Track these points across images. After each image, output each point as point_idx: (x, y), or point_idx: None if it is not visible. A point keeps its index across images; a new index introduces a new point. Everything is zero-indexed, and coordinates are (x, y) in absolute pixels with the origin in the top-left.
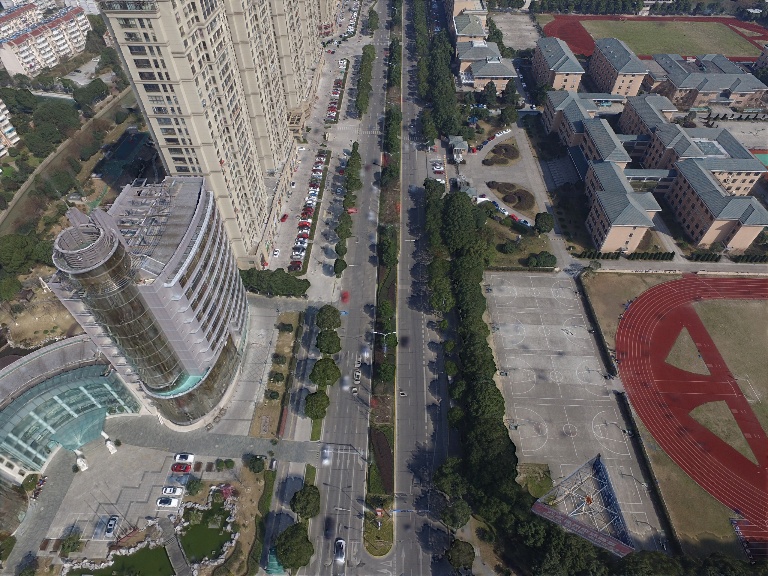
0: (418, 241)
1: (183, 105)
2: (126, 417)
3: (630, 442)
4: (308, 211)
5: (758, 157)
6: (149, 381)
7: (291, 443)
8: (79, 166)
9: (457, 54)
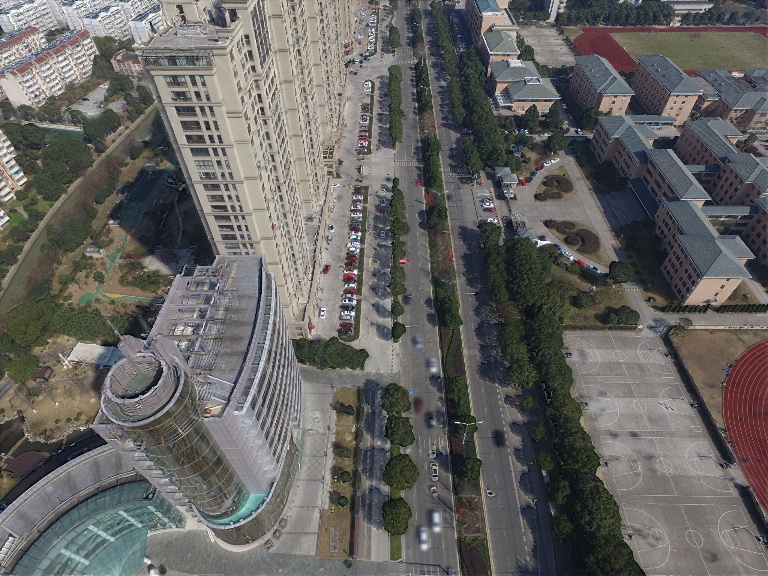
0: (478, 294)
1: (236, 170)
2: (170, 533)
3: (767, 553)
4: (352, 260)
5: None
6: (205, 509)
7: (368, 564)
8: (94, 211)
9: (490, 74)
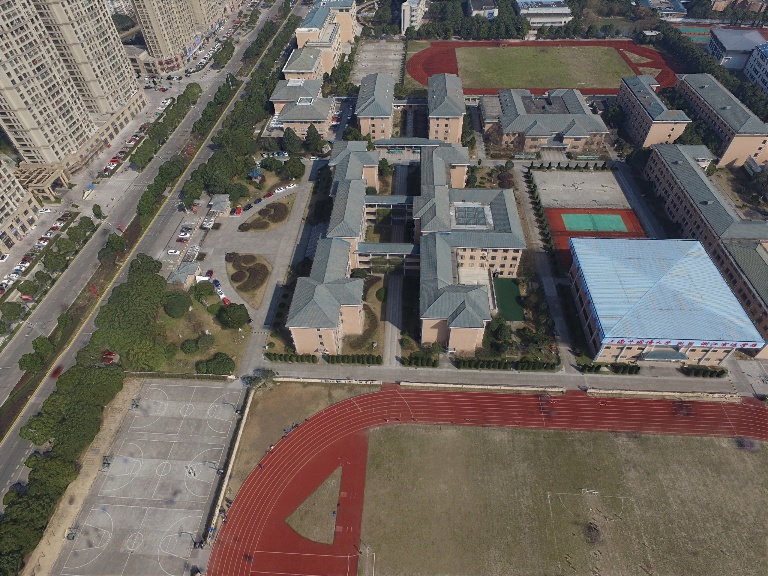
0: None
1: None
2: None
3: None
4: None
5: (564, 218)
6: None
7: None
8: None
9: None
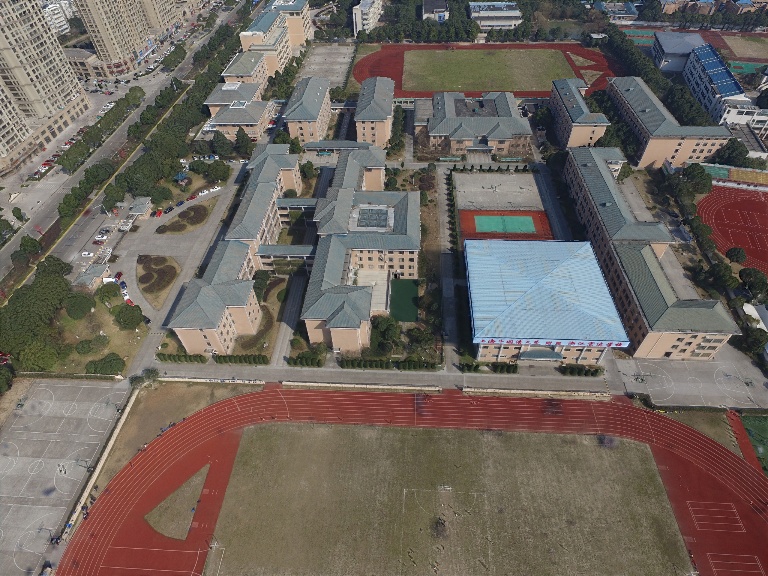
0: None
1: None
2: None
3: None
4: None
5: (476, 220)
6: None
7: None
8: None
9: None
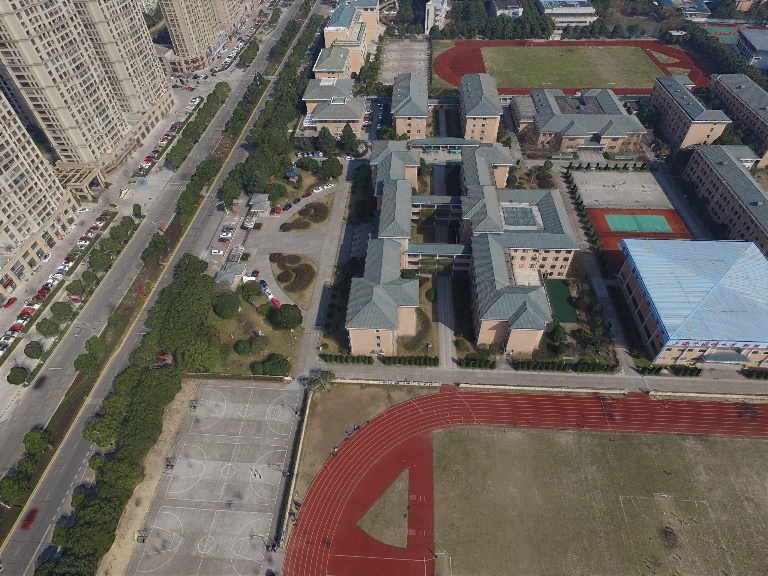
0: None
1: None
2: None
3: None
4: (42, 293)
5: (608, 219)
6: None
7: None
8: None
9: None
